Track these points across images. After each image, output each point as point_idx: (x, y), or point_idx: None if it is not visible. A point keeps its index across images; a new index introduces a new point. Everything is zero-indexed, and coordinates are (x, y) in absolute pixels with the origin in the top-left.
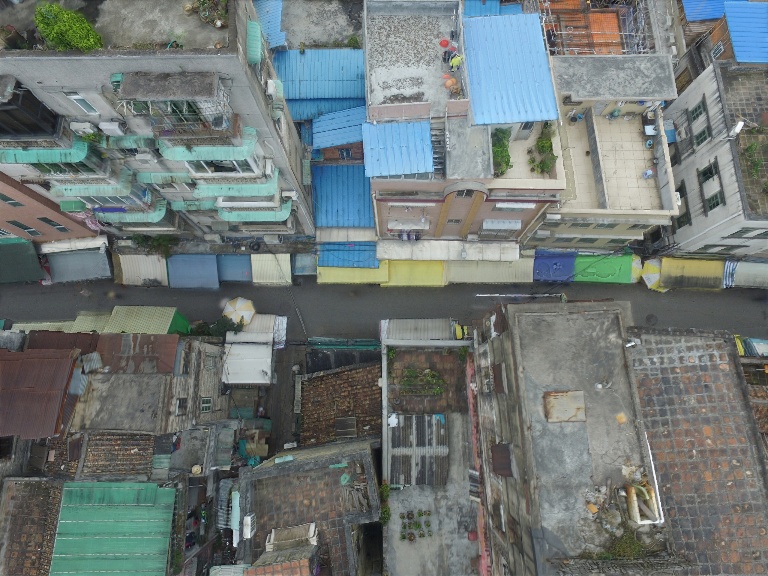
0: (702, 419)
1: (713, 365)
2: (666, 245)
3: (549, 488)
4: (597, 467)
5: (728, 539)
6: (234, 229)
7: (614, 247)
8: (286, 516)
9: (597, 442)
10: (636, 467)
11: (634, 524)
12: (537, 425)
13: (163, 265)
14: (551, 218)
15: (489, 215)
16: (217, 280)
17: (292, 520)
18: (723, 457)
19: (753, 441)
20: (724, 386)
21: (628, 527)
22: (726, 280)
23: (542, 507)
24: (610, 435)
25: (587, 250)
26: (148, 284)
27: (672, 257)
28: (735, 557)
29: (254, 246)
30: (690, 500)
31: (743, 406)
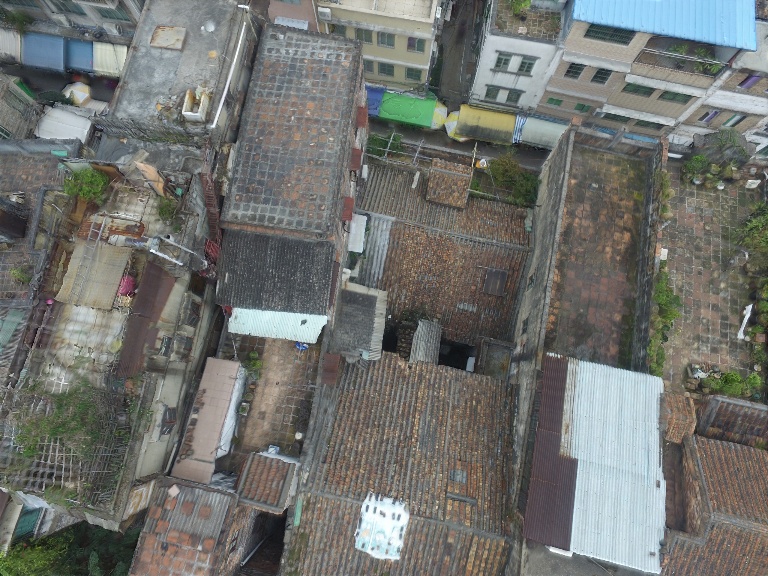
0: (310, 97)
1: (337, 62)
2: (469, 97)
3: (132, 91)
4: (178, 84)
5: (294, 182)
6: (76, 10)
7: (414, 84)
8: (3, 184)
9: (185, 67)
10: (209, 88)
11: (190, 126)
12: (142, 49)
13: (18, 41)
14: (321, 11)
15: (278, 9)
16: (62, 62)
17: (7, 188)
18: (315, 125)
19: (344, 117)
20: (339, 77)
21: (183, 126)
22: (515, 135)
23: (121, 103)
24: (198, 64)
25: (394, 88)
26: (4, 58)
27: (467, 104)
28: (295, 196)
29: (97, 34)
30: (275, 151)
31: (348, 93)
